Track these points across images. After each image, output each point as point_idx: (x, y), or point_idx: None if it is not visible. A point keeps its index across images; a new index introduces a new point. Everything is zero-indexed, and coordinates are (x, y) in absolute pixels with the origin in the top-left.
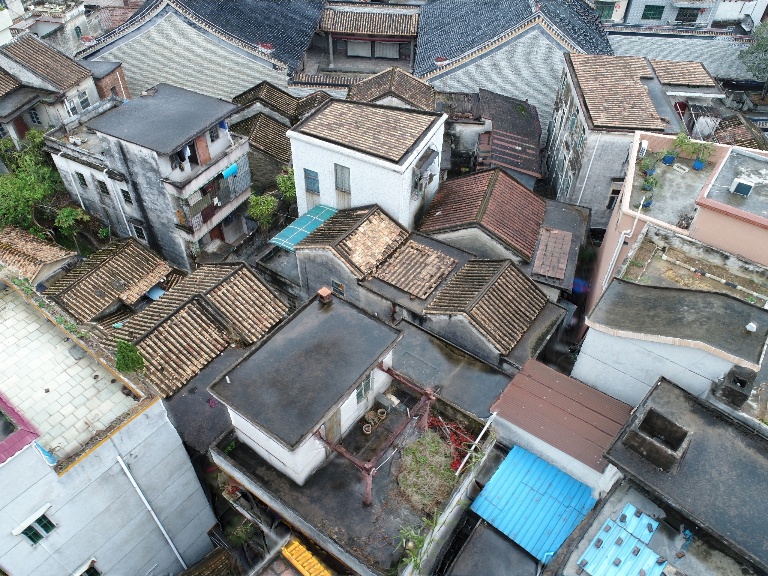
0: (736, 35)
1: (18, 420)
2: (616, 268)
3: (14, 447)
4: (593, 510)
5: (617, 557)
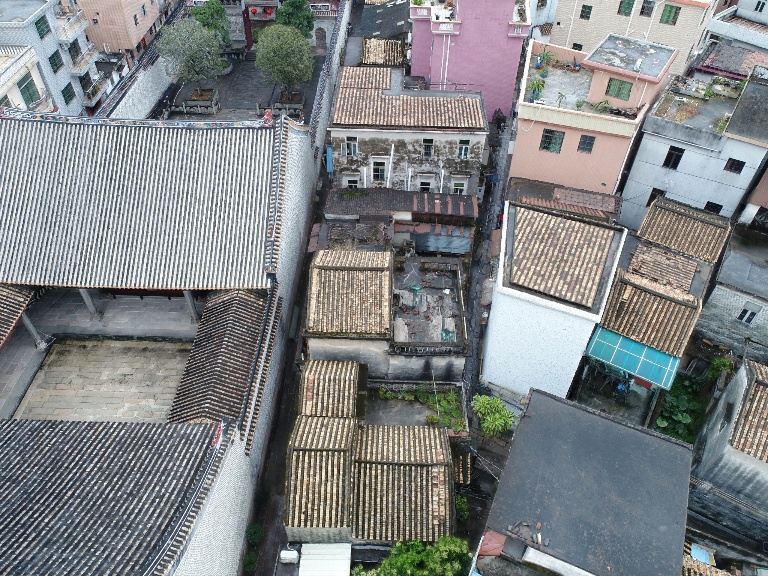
0: (142, 65)
1: None
2: None
3: None
4: None
5: None
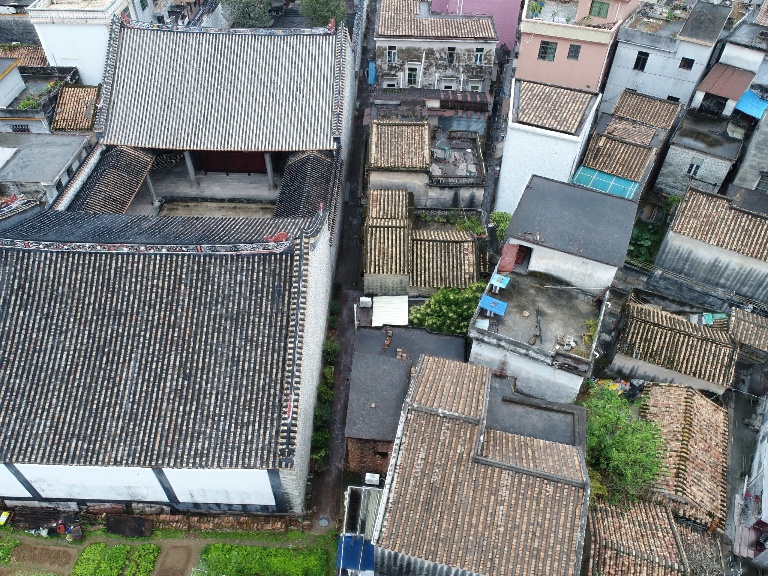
0: (206, 11)
1: None
2: (604, 66)
3: None
4: (762, 86)
5: None
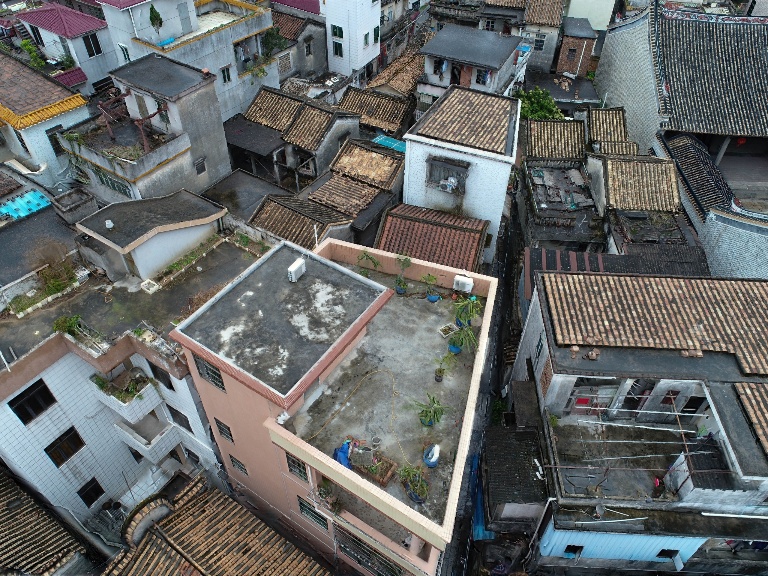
0: None
1: (128, 2)
2: None
3: (115, 3)
4: None
5: (31, 202)
